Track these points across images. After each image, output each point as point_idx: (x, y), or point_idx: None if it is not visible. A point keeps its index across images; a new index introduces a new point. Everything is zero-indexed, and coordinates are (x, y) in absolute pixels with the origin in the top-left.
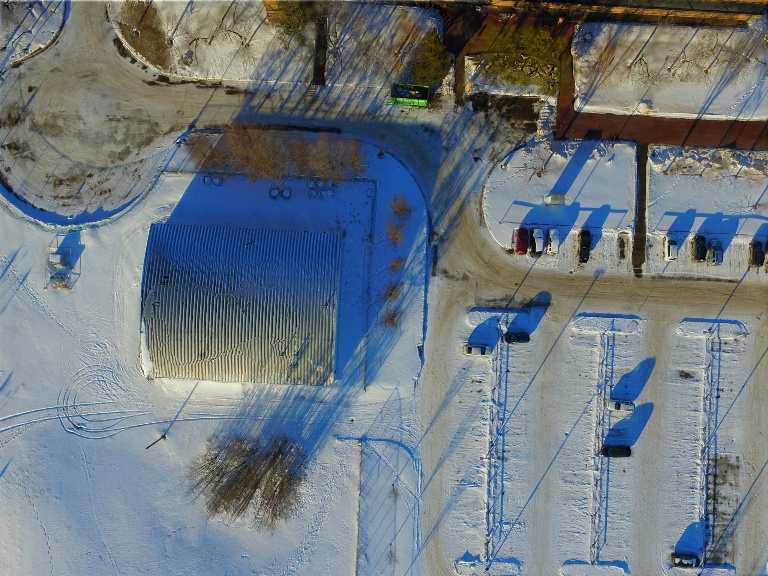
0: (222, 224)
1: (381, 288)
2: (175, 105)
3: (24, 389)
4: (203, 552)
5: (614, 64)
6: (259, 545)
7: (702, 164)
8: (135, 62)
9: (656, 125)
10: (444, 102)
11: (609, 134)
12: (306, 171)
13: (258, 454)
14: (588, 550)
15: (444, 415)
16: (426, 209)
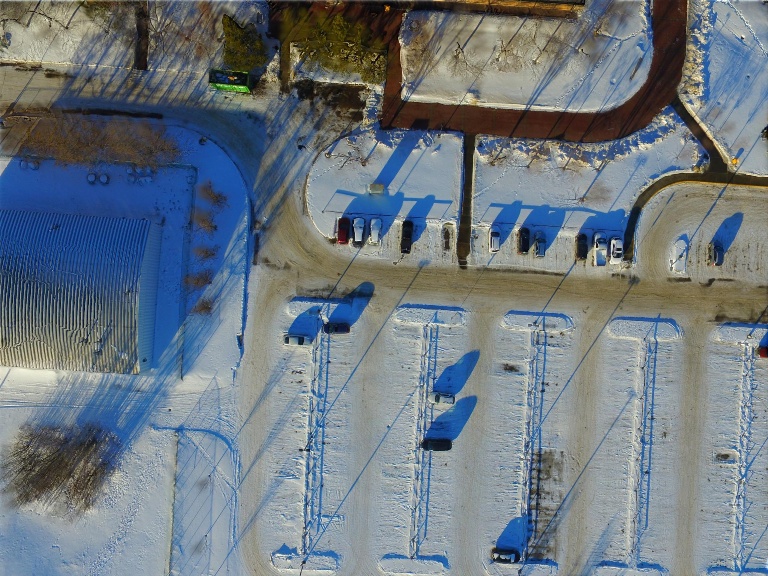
0: (38, 209)
1: (199, 276)
2: None
3: None
4: (12, 541)
5: (441, 53)
6: (71, 535)
7: (530, 155)
8: None
9: (484, 115)
10: (269, 89)
11: (436, 124)
12: (120, 156)
13: (72, 443)
14: (408, 544)
15: (263, 406)
16: (248, 197)
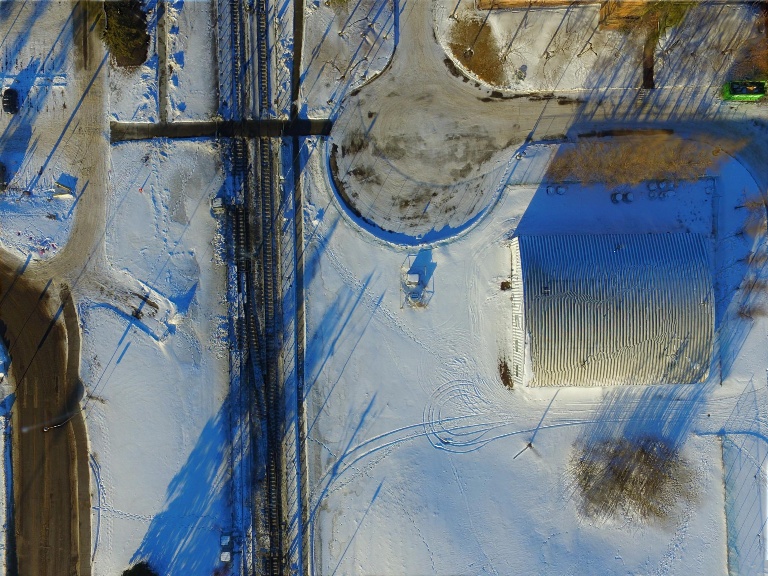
0: (568, 232)
1: (729, 283)
2: (511, 119)
3: (389, 409)
4: (578, 556)
5: None
6: (631, 546)
7: None
8: (468, 80)
9: None
10: None
11: None
12: (656, 173)
13: (621, 456)
14: None
15: None
16: (764, 202)
